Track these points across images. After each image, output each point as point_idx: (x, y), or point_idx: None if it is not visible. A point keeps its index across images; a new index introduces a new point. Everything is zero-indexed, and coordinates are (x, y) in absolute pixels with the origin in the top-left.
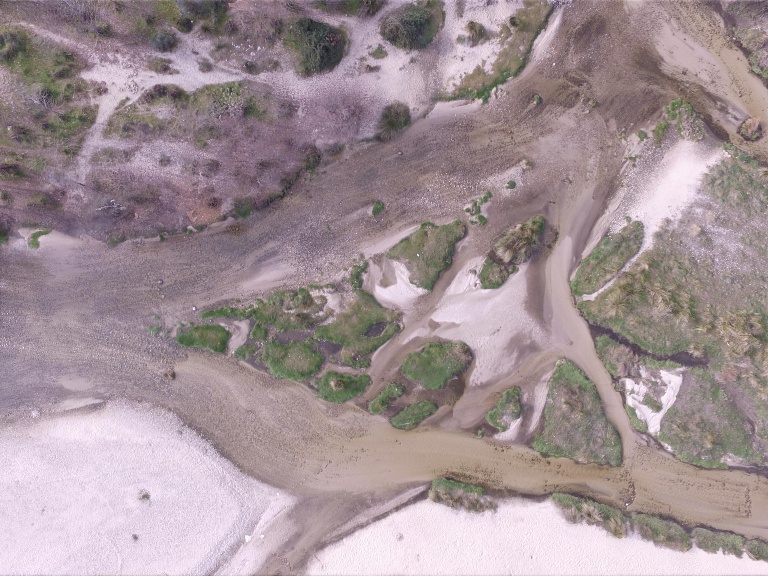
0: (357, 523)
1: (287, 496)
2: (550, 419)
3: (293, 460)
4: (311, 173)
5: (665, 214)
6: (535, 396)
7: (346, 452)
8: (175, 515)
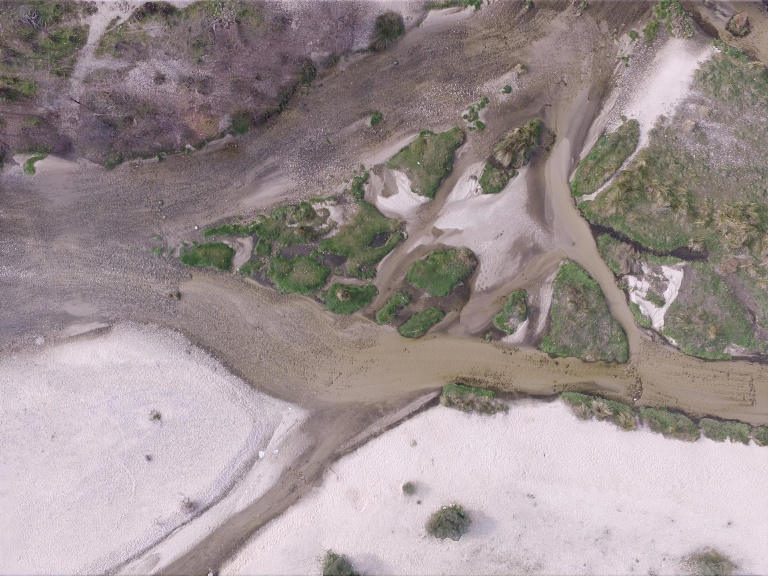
0: (370, 433)
1: (299, 410)
2: (556, 319)
3: (303, 374)
4: (308, 87)
5: (659, 111)
6: (540, 298)
7: (356, 363)
8: (187, 434)
